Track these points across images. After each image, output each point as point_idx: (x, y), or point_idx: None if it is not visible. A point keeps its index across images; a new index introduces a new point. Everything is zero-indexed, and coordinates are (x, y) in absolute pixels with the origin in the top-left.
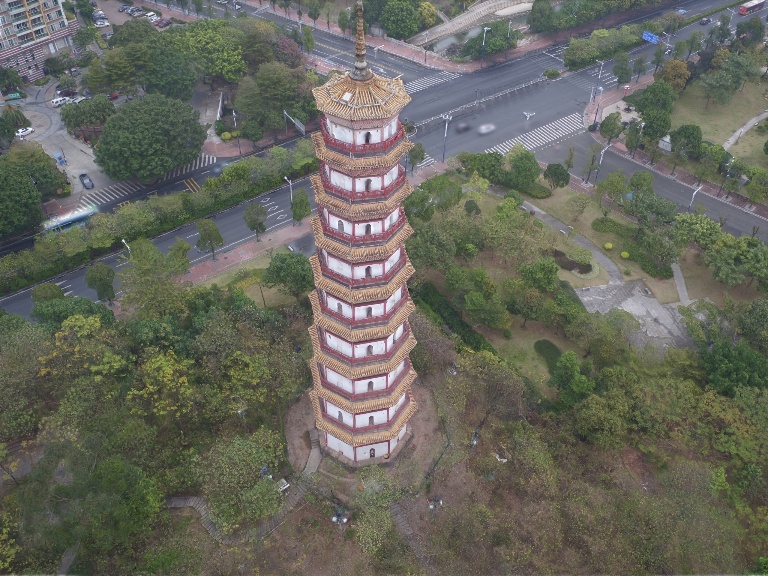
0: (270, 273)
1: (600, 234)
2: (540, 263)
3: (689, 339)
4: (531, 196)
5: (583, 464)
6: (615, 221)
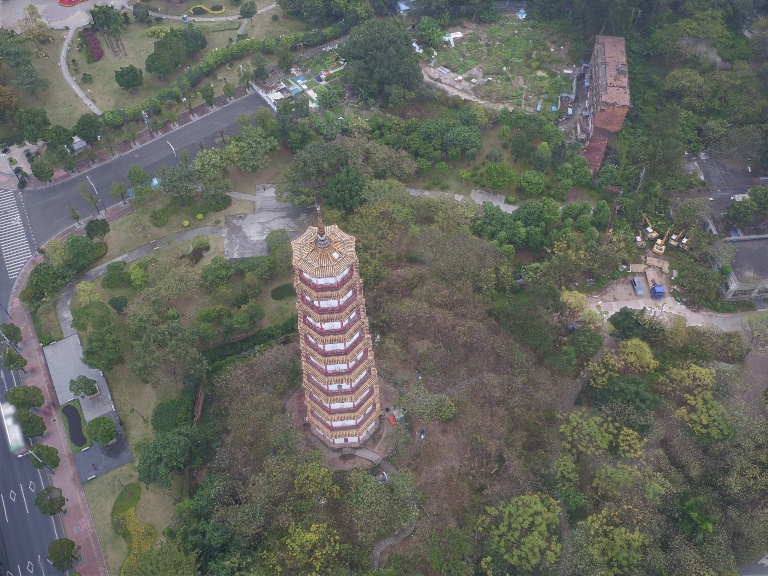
0: (167, 476)
1: (169, 225)
2: (217, 267)
3: (291, 209)
4: (100, 258)
5: (392, 293)
6: (158, 210)
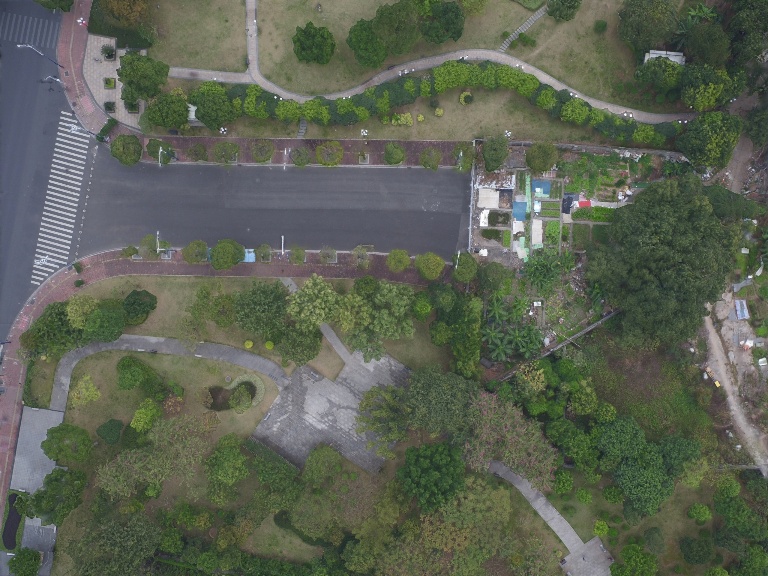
0: None
1: (230, 329)
2: None
3: None
4: (133, 325)
5: None
6: (230, 298)
